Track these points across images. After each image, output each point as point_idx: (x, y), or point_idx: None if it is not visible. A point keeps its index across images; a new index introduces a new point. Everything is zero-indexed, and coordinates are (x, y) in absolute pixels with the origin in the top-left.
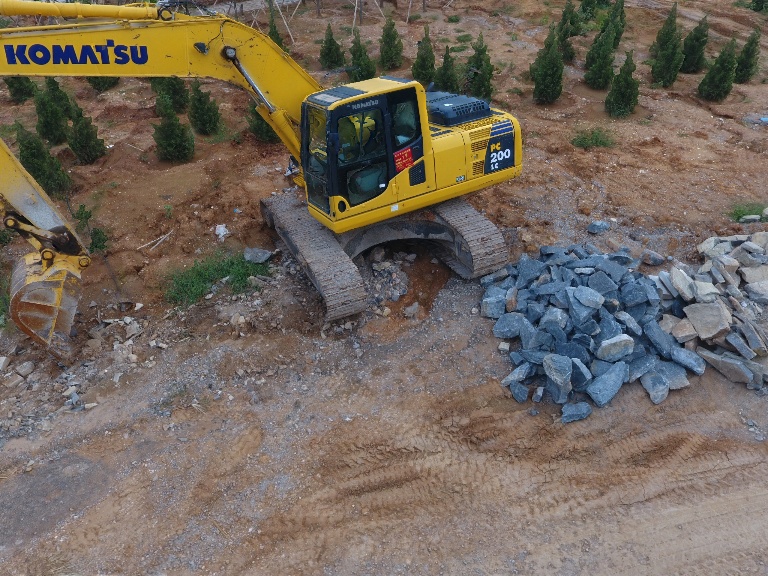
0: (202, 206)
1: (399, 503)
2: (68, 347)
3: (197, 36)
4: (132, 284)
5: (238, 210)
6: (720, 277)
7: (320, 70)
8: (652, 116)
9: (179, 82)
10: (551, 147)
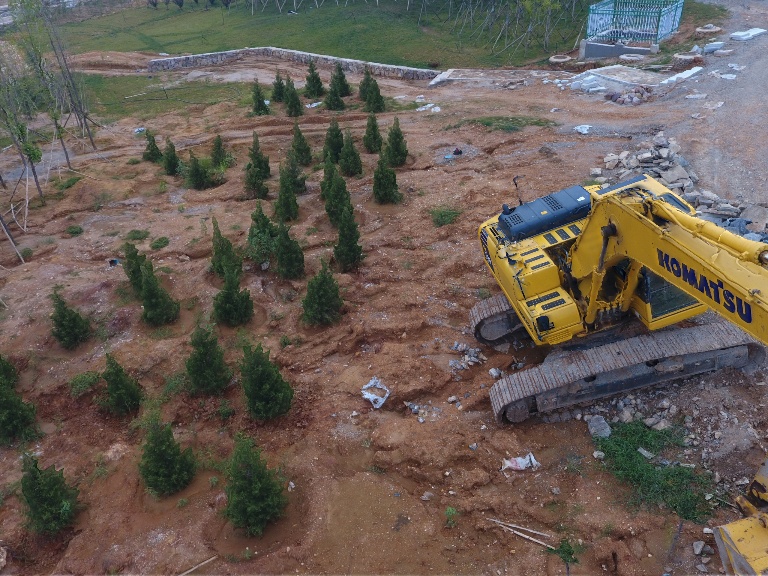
0: (434, 487)
1: None
2: None
3: None
4: (654, 544)
5: (472, 446)
6: (711, 201)
7: (69, 353)
8: (412, 189)
9: None
10: (443, 235)
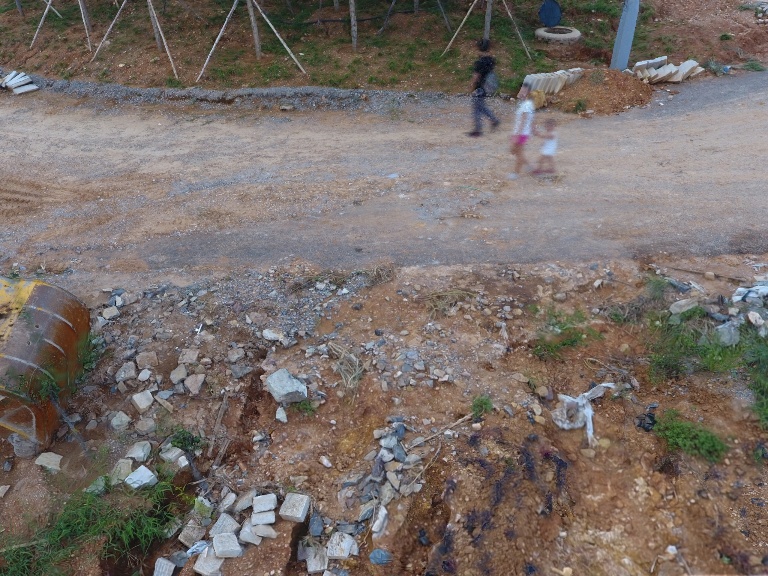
0: None
1: (26, 185)
2: None
3: None
4: None
5: None
6: None
7: None
8: None
9: None
10: None
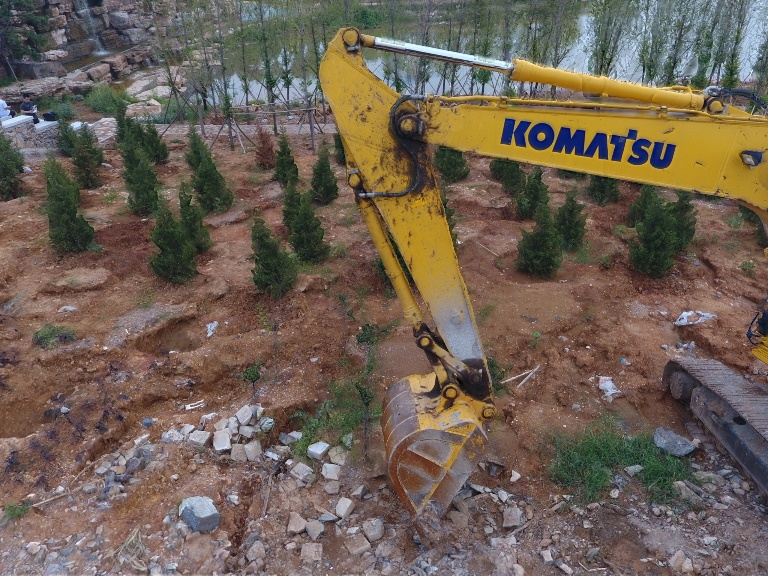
0: (573, 341)
1: None
2: (439, 525)
3: (748, 141)
4: (502, 436)
5: (625, 361)
6: None
7: None
8: None
9: (543, 187)
10: None
